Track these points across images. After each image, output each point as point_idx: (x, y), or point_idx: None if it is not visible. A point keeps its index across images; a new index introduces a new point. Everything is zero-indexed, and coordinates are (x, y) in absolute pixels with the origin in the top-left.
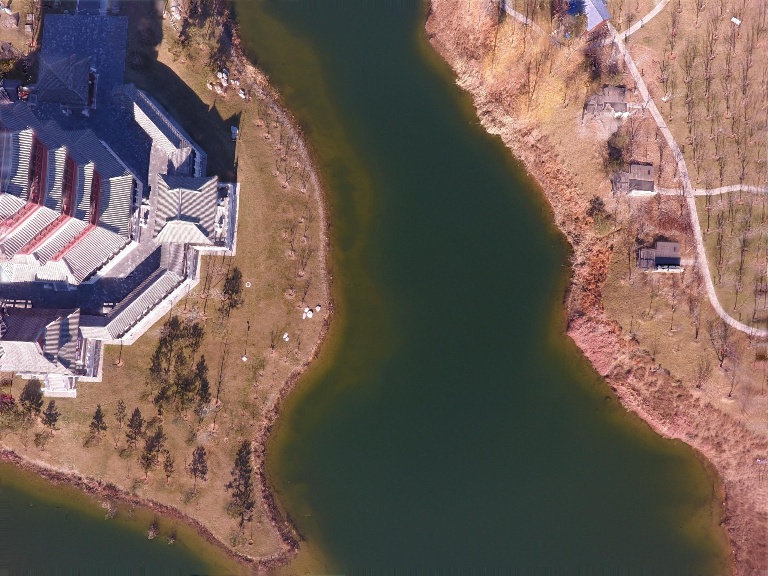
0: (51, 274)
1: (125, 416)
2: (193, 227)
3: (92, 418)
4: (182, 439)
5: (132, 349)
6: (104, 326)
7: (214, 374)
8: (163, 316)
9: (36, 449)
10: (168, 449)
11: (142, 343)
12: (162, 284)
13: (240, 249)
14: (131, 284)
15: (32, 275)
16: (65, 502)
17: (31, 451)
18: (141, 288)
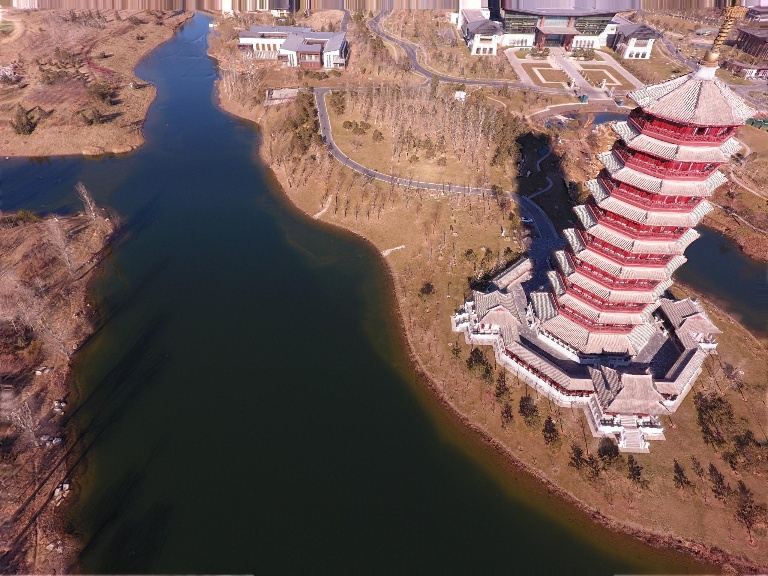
0: (614, 348)
1: (703, 471)
2: (705, 321)
3: (673, 472)
4: (767, 495)
5: (677, 415)
6: (673, 382)
7: (760, 437)
8: (689, 392)
9: (624, 507)
10: (759, 505)
11: (683, 411)
12: (697, 358)
13: (719, 350)
14: (656, 367)
15: (600, 348)
16: (672, 572)
17: (619, 510)
18: (682, 360)
